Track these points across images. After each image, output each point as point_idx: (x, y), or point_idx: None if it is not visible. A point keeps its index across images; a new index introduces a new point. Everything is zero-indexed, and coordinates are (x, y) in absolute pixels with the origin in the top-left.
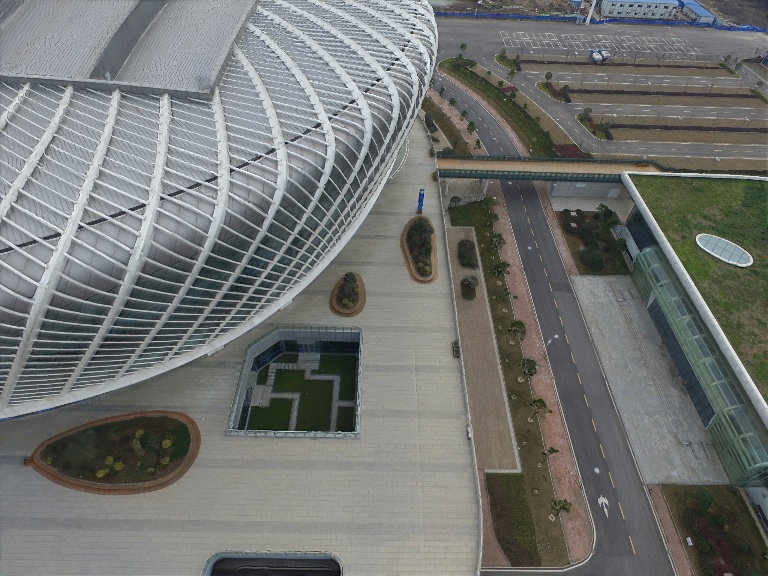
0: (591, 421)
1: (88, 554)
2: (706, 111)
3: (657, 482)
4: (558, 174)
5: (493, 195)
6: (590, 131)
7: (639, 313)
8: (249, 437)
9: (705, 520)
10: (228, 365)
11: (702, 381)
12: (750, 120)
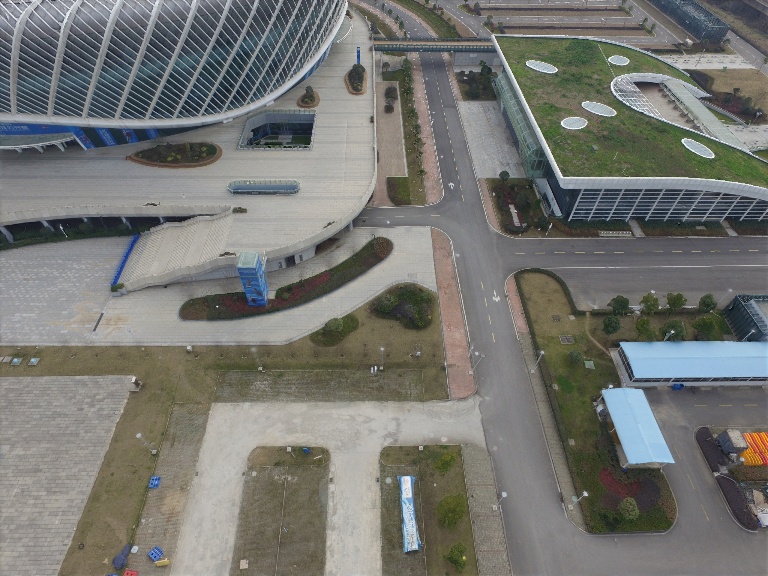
0: (453, 158)
1: (167, 185)
2: (580, 19)
3: (484, 178)
4: (456, 47)
5: (414, 65)
6: (490, 31)
7: (496, 116)
8: (249, 150)
9: (505, 186)
10: (236, 126)
11: (515, 129)
12: (605, 20)
